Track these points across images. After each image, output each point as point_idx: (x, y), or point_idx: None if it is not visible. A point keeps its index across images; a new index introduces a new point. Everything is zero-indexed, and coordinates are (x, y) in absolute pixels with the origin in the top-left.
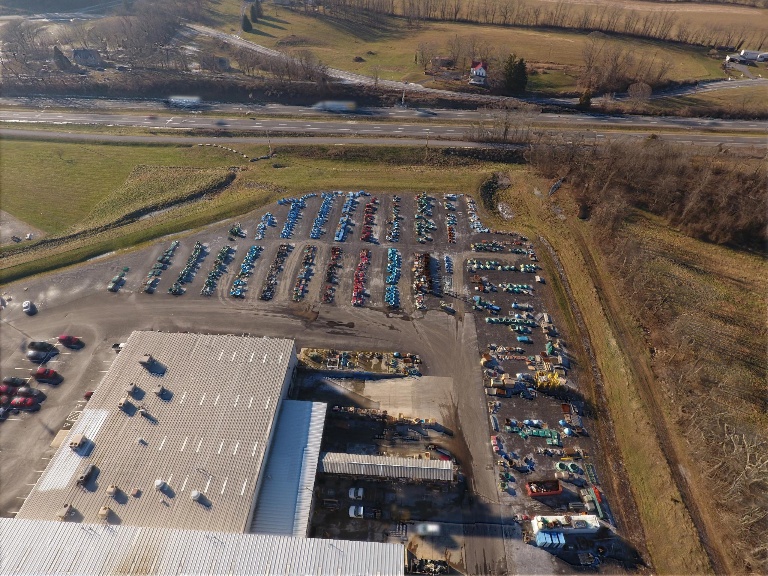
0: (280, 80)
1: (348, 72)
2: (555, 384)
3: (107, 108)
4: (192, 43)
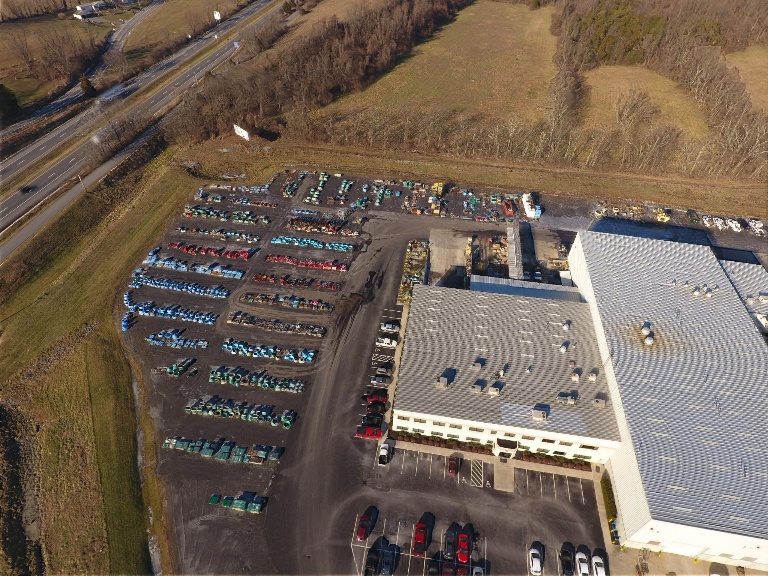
0: None
1: None
2: None
3: None
4: None
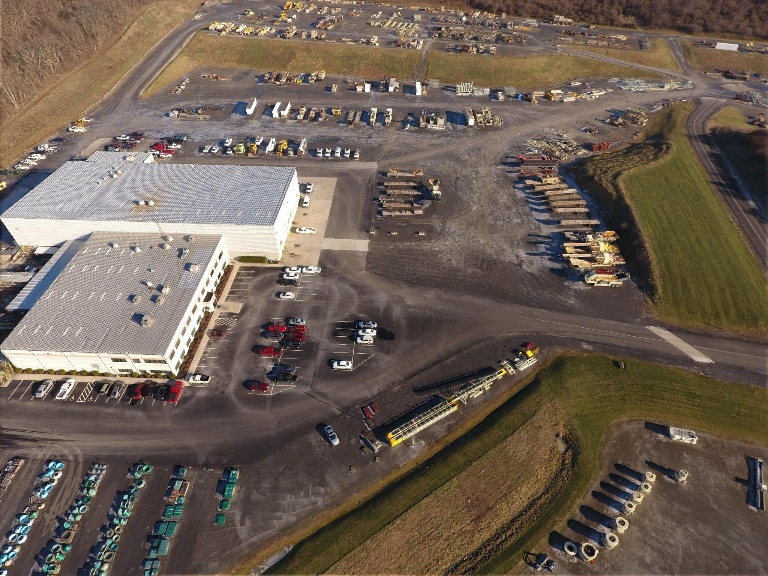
0: None
1: None
2: None
3: None
4: None
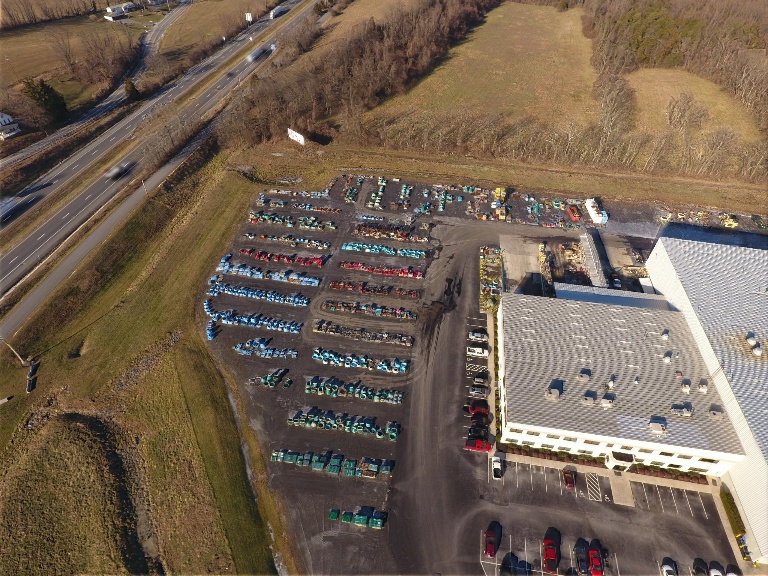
0: None
1: None
2: None
3: None
4: None
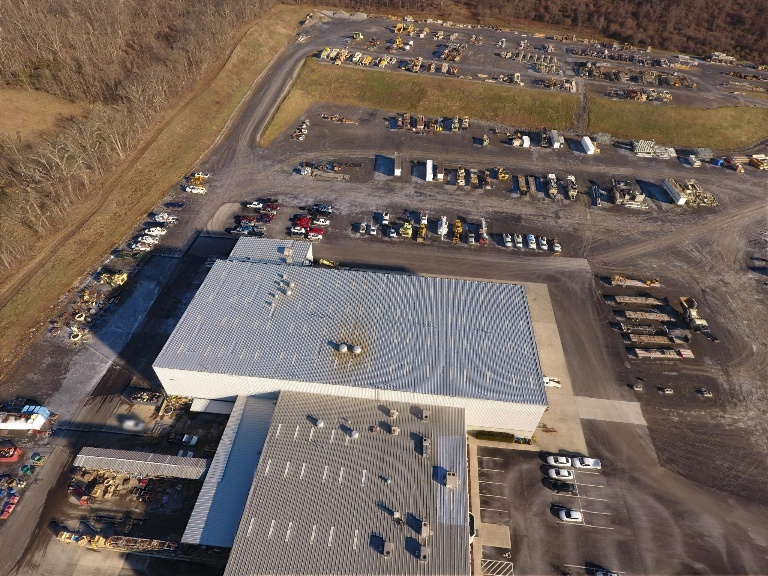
0: None
1: None
2: None
3: None
4: None
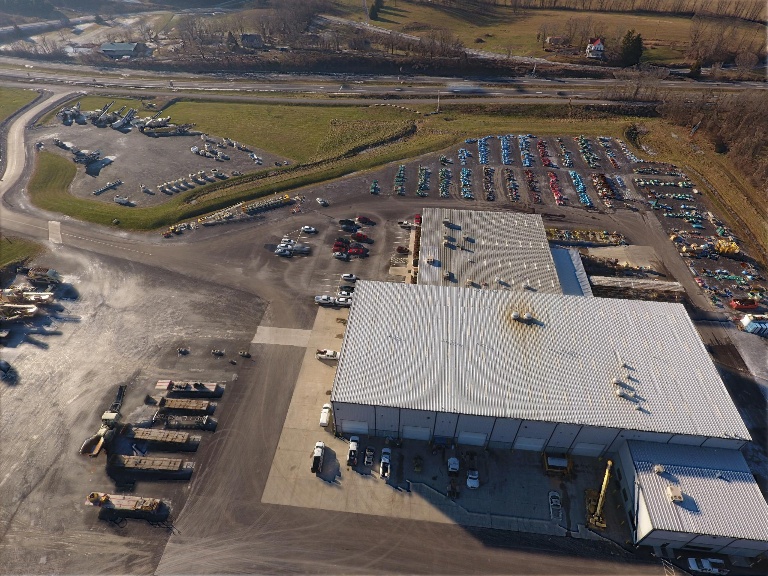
0: (424, 56)
1: (478, 50)
2: (733, 250)
3: (284, 80)
4: (328, 30)
